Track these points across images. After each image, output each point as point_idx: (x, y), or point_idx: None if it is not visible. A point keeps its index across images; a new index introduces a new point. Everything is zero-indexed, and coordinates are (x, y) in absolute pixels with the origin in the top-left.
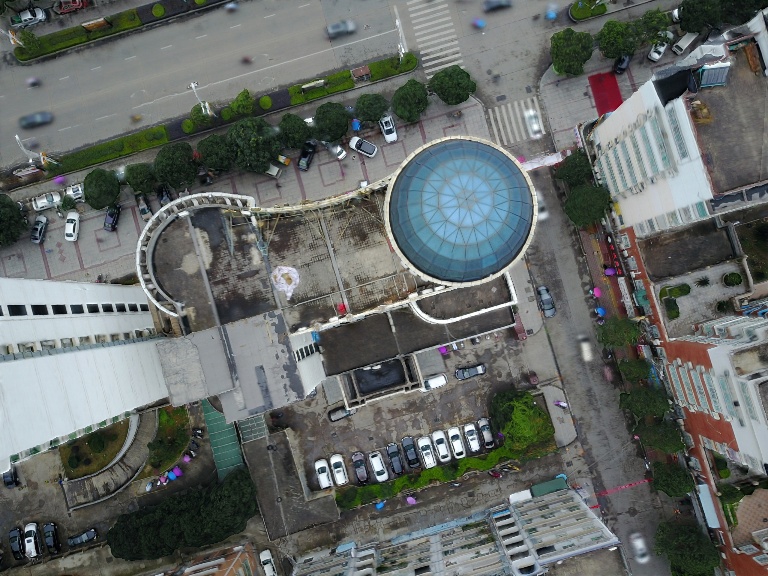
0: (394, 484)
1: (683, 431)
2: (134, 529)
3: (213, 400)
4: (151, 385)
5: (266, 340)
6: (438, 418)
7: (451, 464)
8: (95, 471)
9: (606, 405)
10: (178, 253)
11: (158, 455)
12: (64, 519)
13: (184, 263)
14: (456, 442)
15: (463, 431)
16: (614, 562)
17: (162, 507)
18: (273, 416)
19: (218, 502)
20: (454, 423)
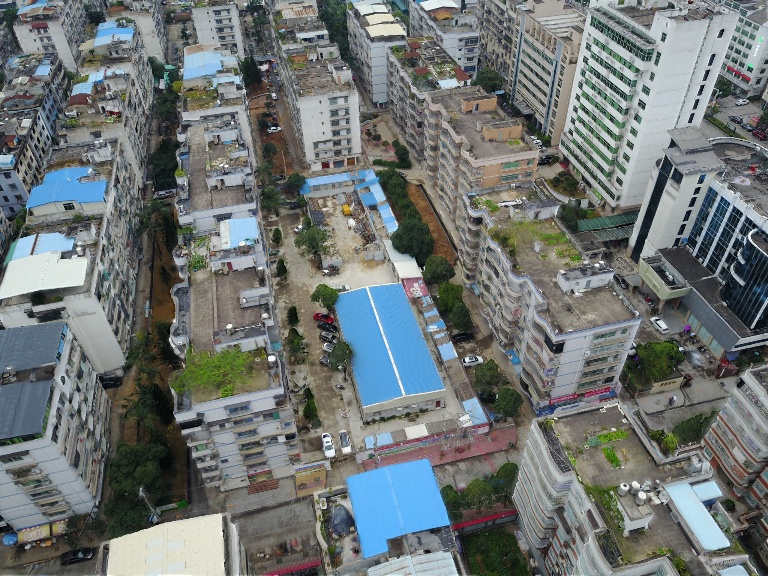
0: None
1: None
2: None
3: (661, 160)
4: (642, 164)
5: (711, 164)
6: None
7: None
8: (551, 188)
9: None
10: (734, 150)
11: (572, 204)
12: None
13: (730, 151)
14: None
15: None
16: None
17: None
18: None
19: None
20: None
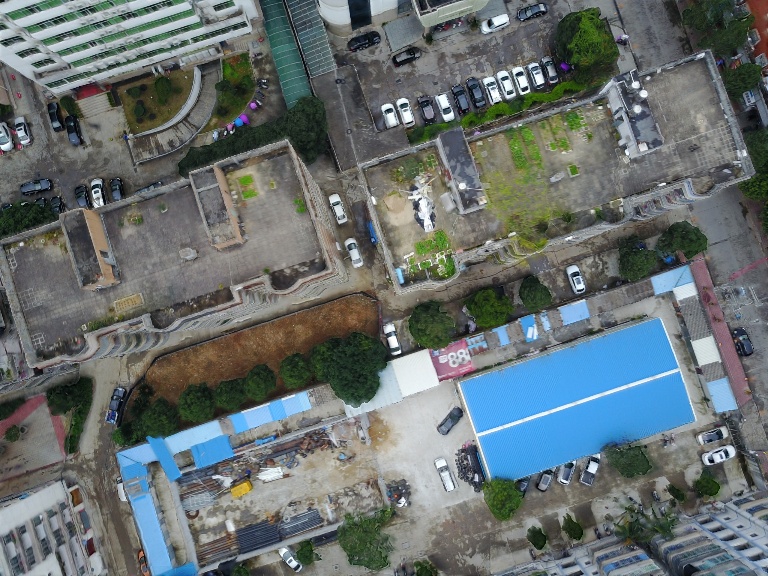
0: (461, 121)
1: (748, 30)
2: (208, 150)
3: None
4: None
5: None
6: (501, 60)
7: (517, 98)
8: (160, 125)
9: (666, 42)
10: None
11: (226, 97)
12: (130, 175)
13: None
14: (521, 77)
15: (527, 70)
16: (701, 75)
17: (234, 133)
18: (338, 64)
19: (292, 117)
20: (517, 64)
